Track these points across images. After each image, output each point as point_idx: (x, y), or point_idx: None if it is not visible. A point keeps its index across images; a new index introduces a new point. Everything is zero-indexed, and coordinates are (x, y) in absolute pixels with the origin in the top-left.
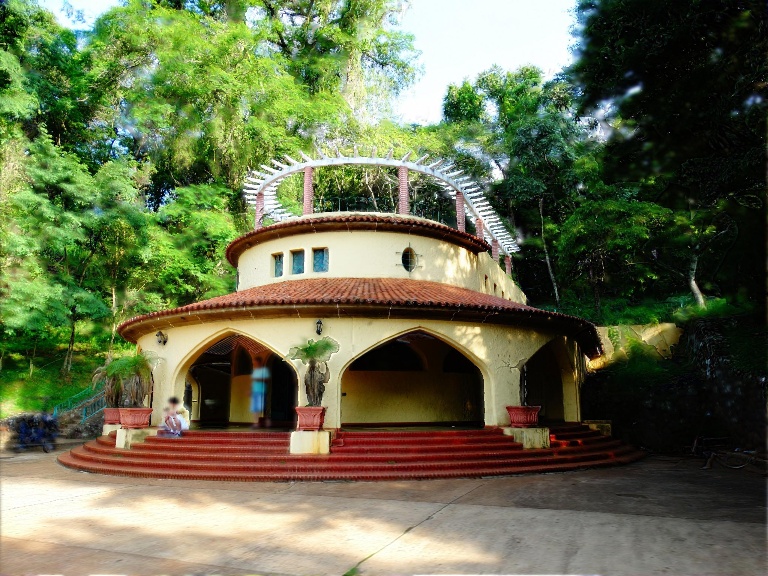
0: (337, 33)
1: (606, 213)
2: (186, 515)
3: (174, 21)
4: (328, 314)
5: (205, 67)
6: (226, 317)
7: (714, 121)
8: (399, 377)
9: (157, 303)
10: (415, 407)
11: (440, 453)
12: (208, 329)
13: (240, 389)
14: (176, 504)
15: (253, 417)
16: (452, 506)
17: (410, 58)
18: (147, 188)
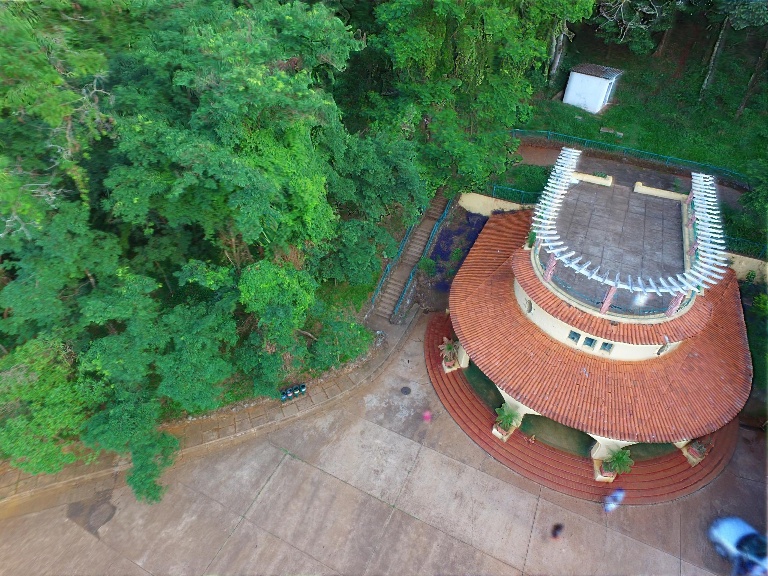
0: None
1: None
2: (598, 567)
3: None
4: None
5: (478, 7)
6: None
7: None
8: None
9: None
10: None
11: (658, 481)
12: None
13: None
14: (583, 546)
15: None
16: (683, 565)
17: None
18: None
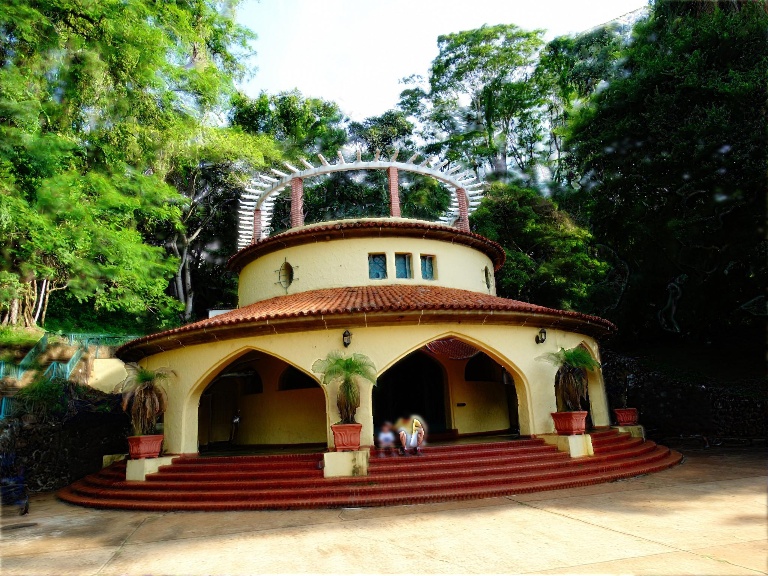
0: (203, 2)
1: None
2: (756, 502)
3: None
4: (545, 324)
5: None
6: (455, 320)
7: None
8: (494, 387)
9: (16, 288)
10: (503, 415)
11: None
12: (426, 332)
13: (323, 403)
14: (689, 501)
15: None
16: None
17: (241, 55)
18: (5, 119)
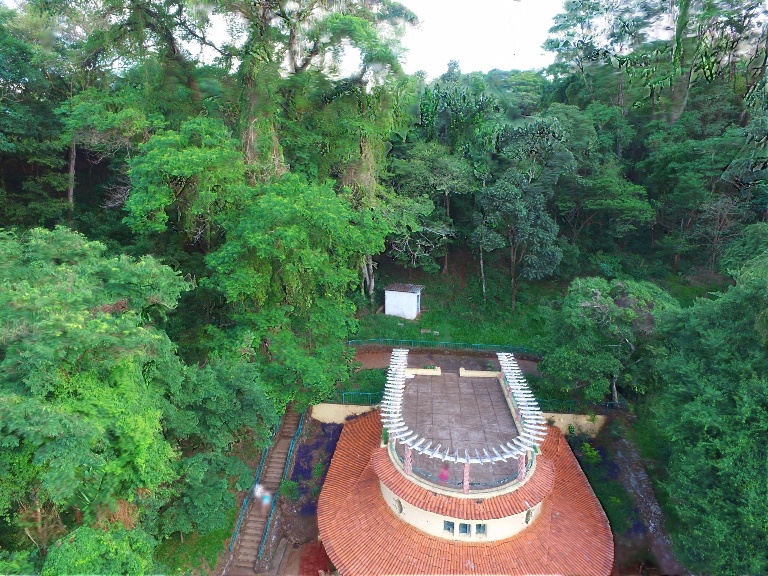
0: None
1: (586, 369)
2: None
3: (231, 159)
4: None
5: None
6: None
7: None
8: None
9: None
10: None
11: None
12: None
13: None
14: None
15: None
16: None
17: (402, 104)
18: None
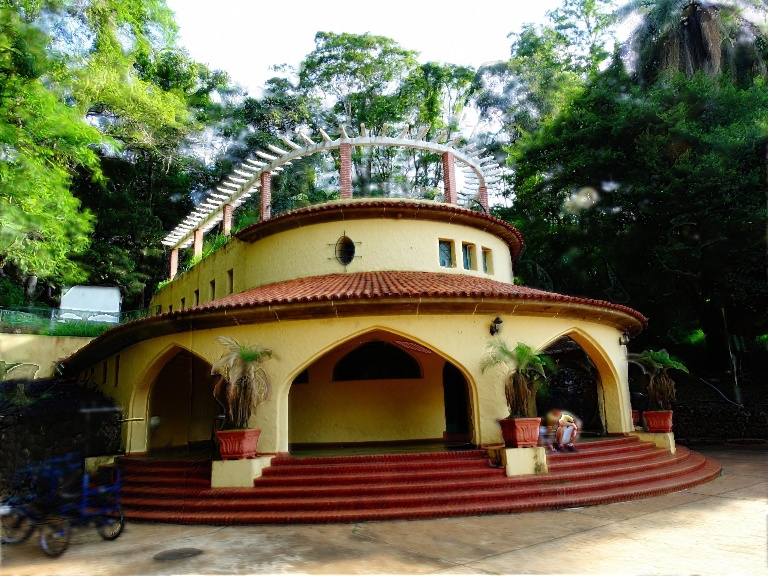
0: None
1: None
2: None
3: None
4: (624, 327)
5: None
6: (582, 315)
7: (762, 261)
8: None
9: None
10: None
11: None
12: (559, 325)
13: (395, 397)
14: None
15: (433, 431)
16: None
17: None
18: None
